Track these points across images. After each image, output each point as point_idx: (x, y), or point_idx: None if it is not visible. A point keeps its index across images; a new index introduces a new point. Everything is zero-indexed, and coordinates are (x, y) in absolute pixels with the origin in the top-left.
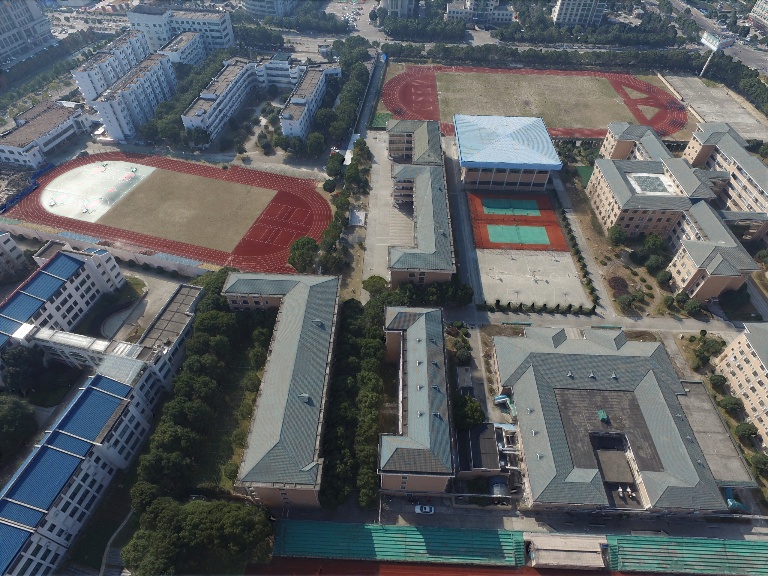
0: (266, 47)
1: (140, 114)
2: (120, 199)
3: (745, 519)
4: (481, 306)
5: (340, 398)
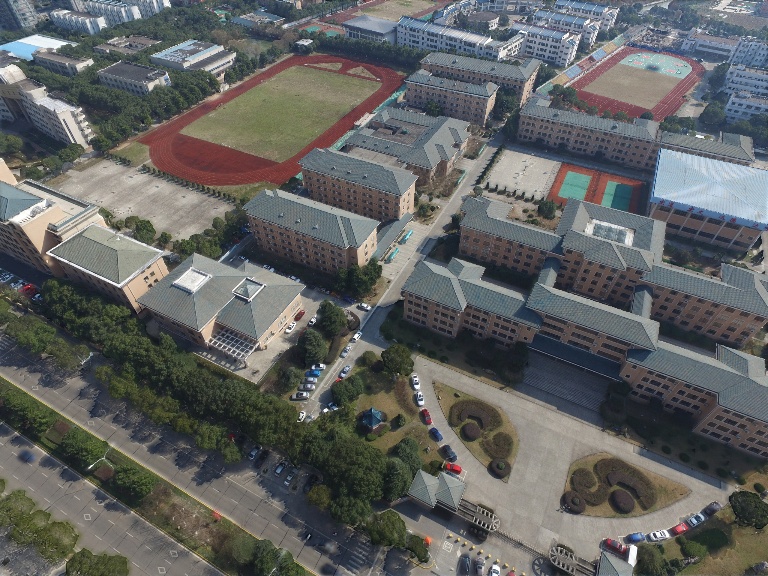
0: None
1: None
2: (643, 68)
3: None
4: None
5: None
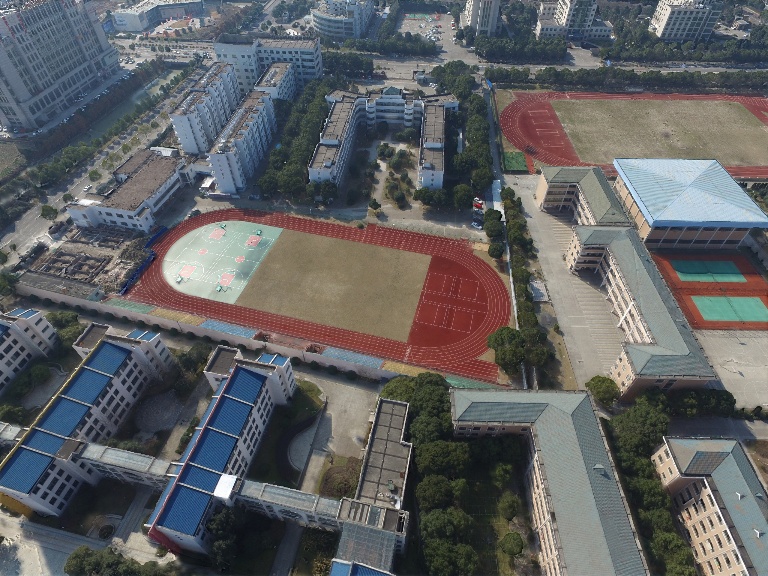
0: (354, 74)
1: (250, 162)
2: (254, 271)
3: None
4: (736, 413)
5: None
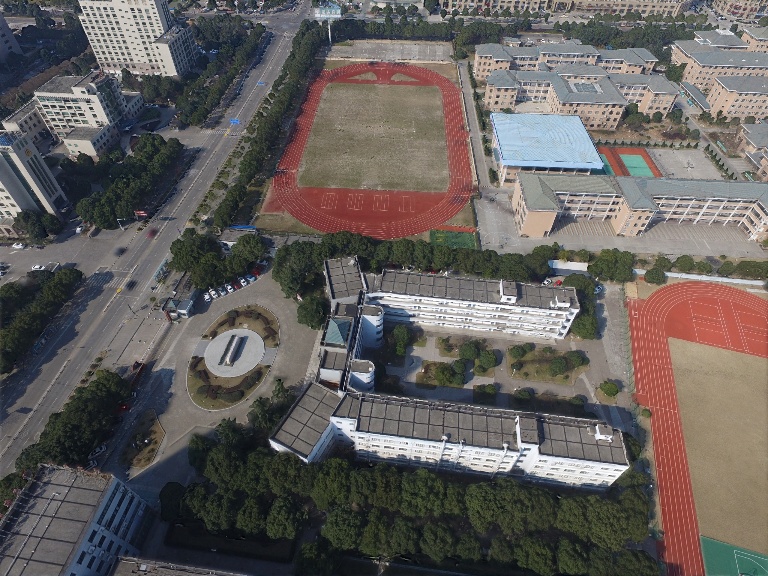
0: None
1: None
2: None
3: None
4: None
5: None
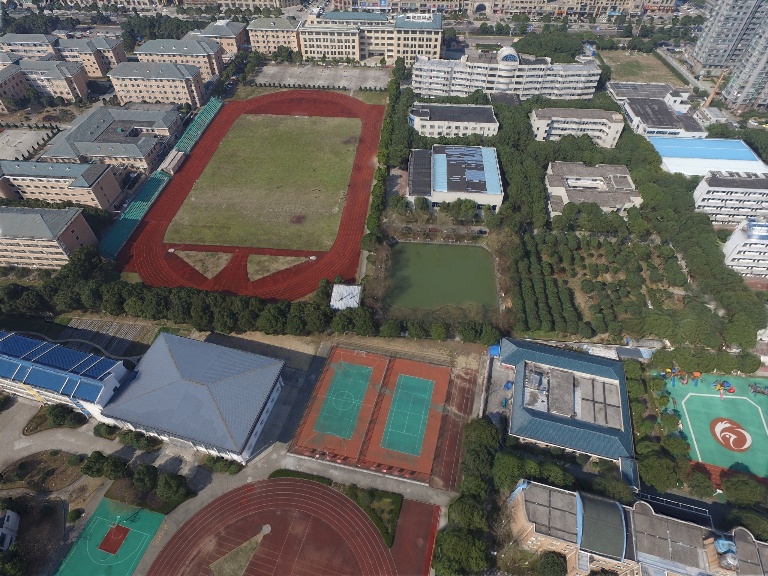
0: None
1: None
2: None
3: (190, 118)
4: None
5: None
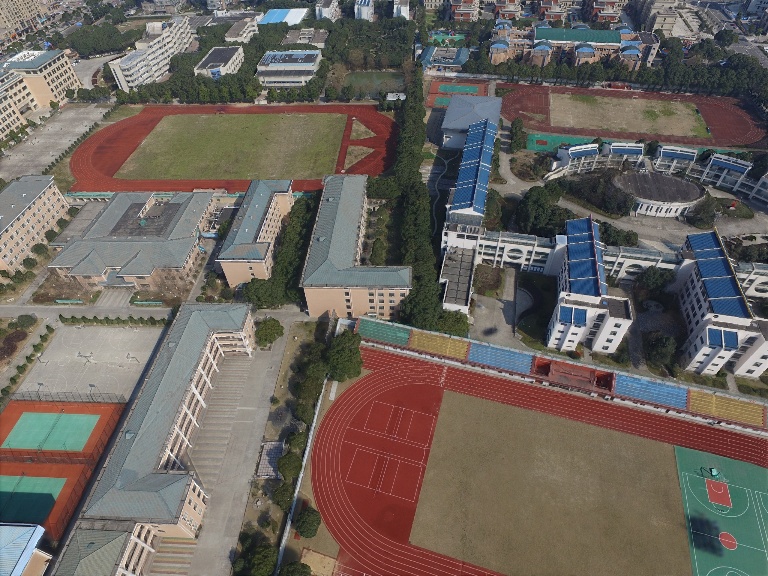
0: None
1: None
2: (685, 509)
3: None
4: (170, 322)
5: (311, 219)
